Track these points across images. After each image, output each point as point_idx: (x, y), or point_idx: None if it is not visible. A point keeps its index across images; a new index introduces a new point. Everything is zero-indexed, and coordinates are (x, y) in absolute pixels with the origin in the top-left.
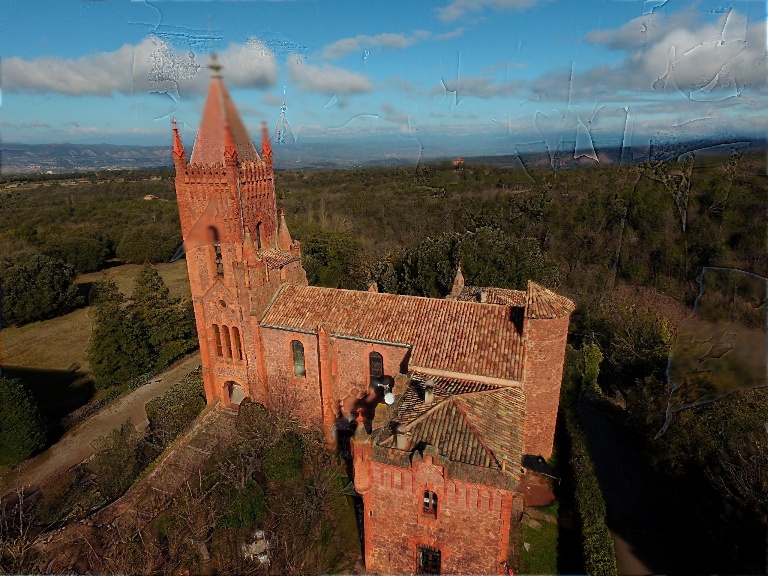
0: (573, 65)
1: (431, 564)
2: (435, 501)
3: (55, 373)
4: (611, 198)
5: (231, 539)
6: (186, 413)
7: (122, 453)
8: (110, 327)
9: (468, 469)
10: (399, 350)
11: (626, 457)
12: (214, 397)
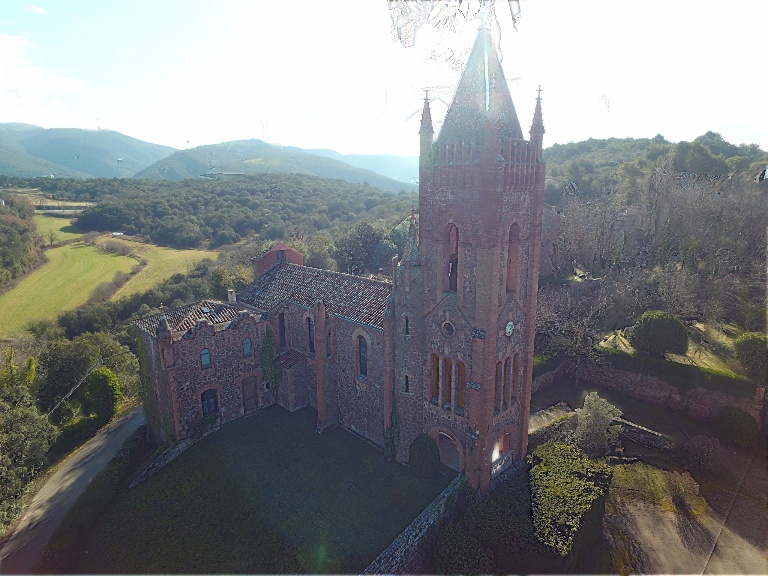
0: None
1: None
2: None
3: None
4: None
5: None
6: None
7: None
8: None
9: None
10: None
11: None
12: None
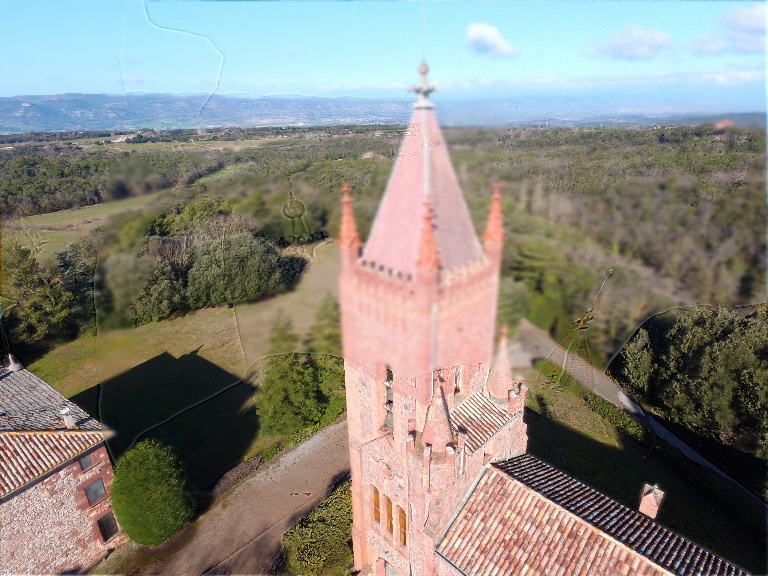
0: None
1: None
2: None
3: (238, 387)
4: None
5: None
6: None
7: None
8: (280, 373)
9: None
10: None
11: None
12: (364, 565)
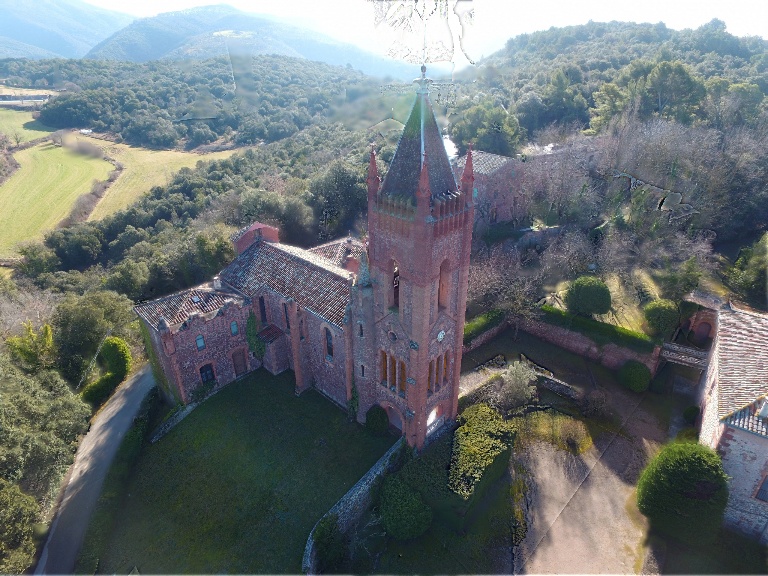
0: None
1: None
2: None
3: None
4: None
5: None
6: None
7: None
8: None
9: None
10: None
11: None
12: None
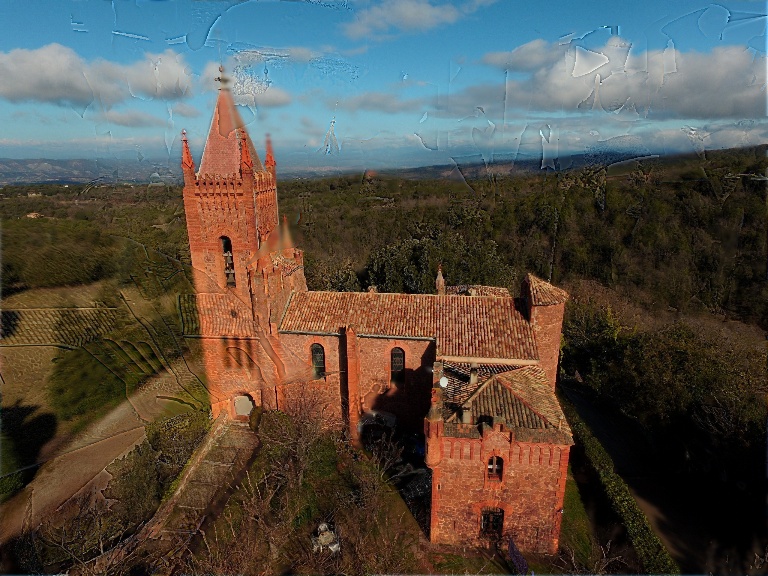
0: (506, 87)
1: (492, 525)
2: (498, 466)
3: None
4: (540, 205)
5: (292, 537)
6: (193, 429)
7: (143, 474)
8: None
9: (531, 432)
10: (421, 344)
11: (604, 423)
12: (221, 410)
